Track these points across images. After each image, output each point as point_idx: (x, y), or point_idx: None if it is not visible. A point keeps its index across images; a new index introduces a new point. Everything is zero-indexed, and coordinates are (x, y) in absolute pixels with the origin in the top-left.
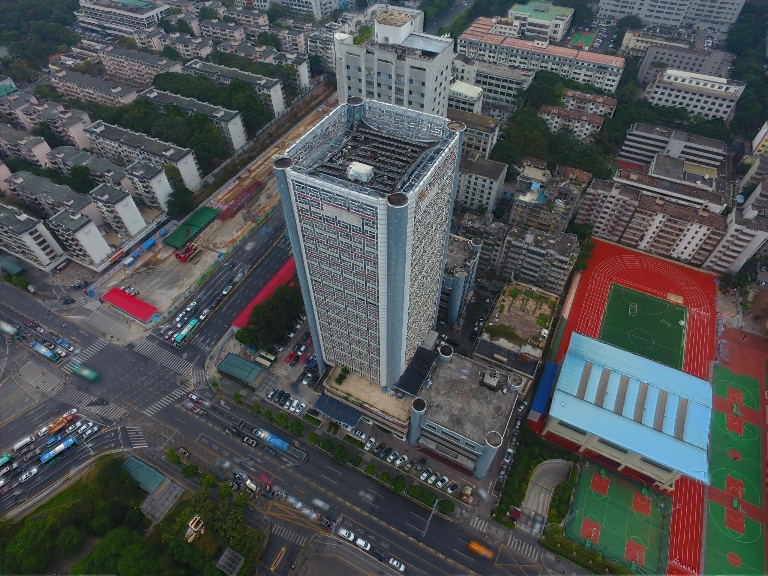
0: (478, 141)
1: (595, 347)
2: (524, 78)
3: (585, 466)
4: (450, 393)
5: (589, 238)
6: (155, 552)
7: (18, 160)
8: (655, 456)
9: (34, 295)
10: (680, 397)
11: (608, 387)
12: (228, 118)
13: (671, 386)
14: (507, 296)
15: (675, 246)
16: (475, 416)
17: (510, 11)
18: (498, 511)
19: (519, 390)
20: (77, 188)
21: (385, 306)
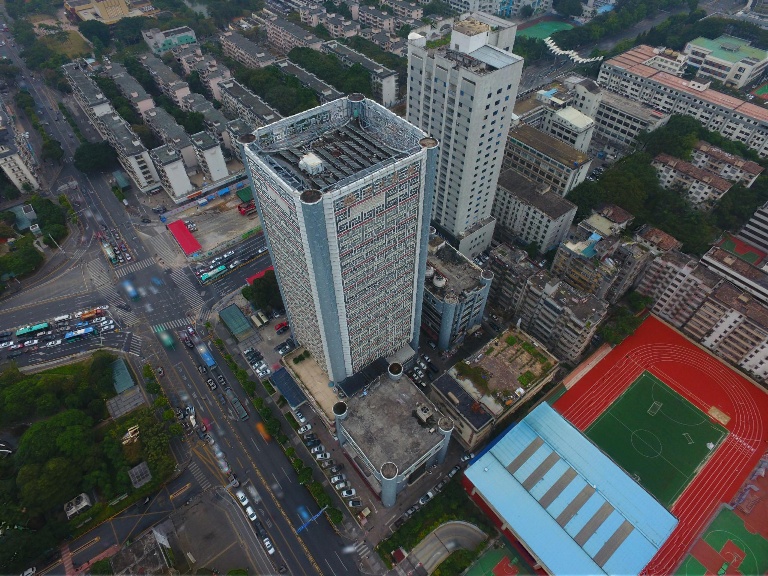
0: (559, 174)
1: (558, 427)
2: (652, 119)
3: (499, 546)
4: (379, 410)
5: (645, 313)
6: (92, 439)
7: (164, 98)
8: (555, 568)
9: (127, 208)
10: (626, 520)
11: (547, 473)
12: (332, 98)
13: (623, 504)
14: (503, 341)
15: (748, 356)
16: (389, 442)
17: (688, 44)
18: (383, 545)
19: (467, 439)
20: (191, 130)
21: (318, 300)
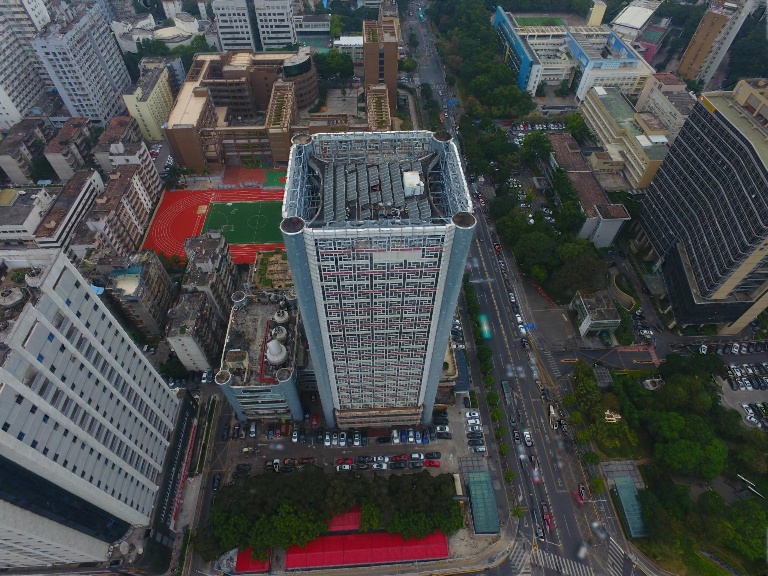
0: None
1: None
2: None
3: None
4: None
5: None
6: None
7: None
8: None
9: None
10: None
11: None
12: None
13: None
14: None
15: None
16: None
17: None
18: None
19: None
20: None
21: None
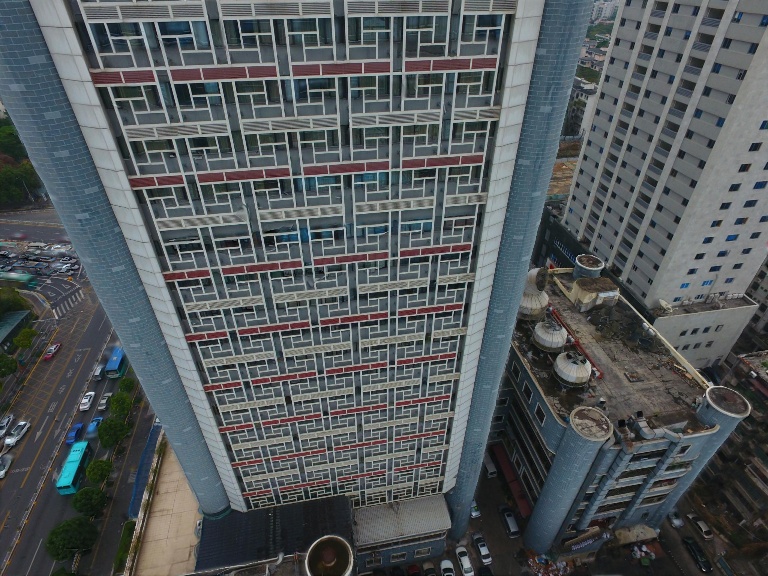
0: None
1: None
2: None
3: None
4: None
5: None
6: None
7: None
8: None
9: None
10: None
11: None
12: None
13: None
14: None
15: None
16: None
17: None
18: None
19: None
20: None
21: None
